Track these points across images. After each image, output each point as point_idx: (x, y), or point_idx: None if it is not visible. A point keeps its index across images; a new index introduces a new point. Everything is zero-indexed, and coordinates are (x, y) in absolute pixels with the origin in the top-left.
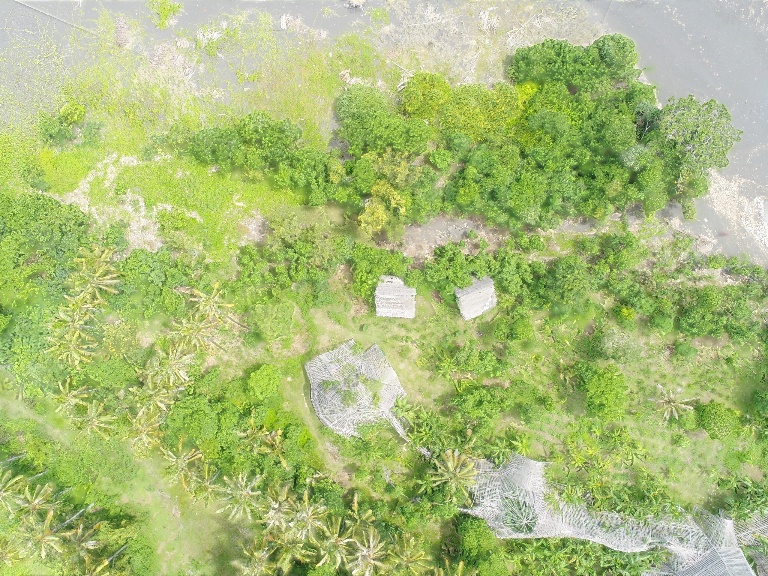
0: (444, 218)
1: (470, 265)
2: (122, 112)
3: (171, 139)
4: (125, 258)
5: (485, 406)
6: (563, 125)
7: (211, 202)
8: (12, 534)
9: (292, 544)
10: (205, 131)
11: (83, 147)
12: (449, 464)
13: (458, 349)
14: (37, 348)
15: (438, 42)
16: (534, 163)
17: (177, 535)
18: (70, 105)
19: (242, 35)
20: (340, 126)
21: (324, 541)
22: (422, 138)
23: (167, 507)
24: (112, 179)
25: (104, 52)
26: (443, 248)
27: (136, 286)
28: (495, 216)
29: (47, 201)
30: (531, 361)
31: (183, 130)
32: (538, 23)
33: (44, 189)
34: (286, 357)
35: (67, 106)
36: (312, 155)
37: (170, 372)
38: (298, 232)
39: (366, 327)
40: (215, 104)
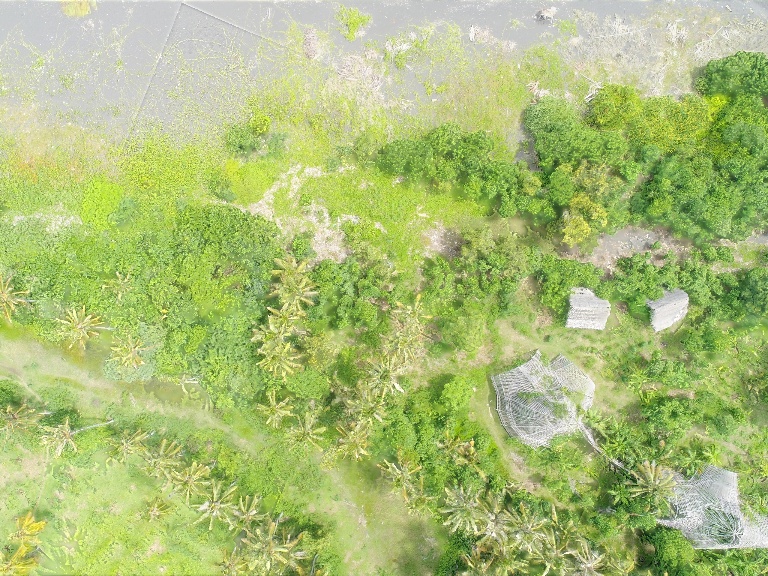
0: (626, 229)
1: (663, 277)
2: (307, 123)
3: (361, 151)
4: (310, 269)
5: (683, 418)
6: (762, 138)
7: (395, 213)
8: (200, 543)
9: (510, 556)
10: (399, 143)
11: (268, 158)
12: (651, 476)
13: (643, 360)
14: (235, 359)
15: (626, 54)
16: (728, 175)
17: (363, 544)
18: (259, 116)
19: (430, 47)
20: (527, 137)
21: (546, 553)
22: (619, 150)
23: (353, 516)
24: (296, 190)
25: (292, 63)
26: (629, 259)
27: (328, 297)
28: (687, 228)
29: (239, 212)
30: (715, 372)
31: (373, 142)
32: (726, 35)
33: (230, 200)
34: (471, 368)
35: (256, 117)
36: (506, 167)
37: (389, 385)
38: (494, 244)
39: (553, 338)
40: (402, 115)
